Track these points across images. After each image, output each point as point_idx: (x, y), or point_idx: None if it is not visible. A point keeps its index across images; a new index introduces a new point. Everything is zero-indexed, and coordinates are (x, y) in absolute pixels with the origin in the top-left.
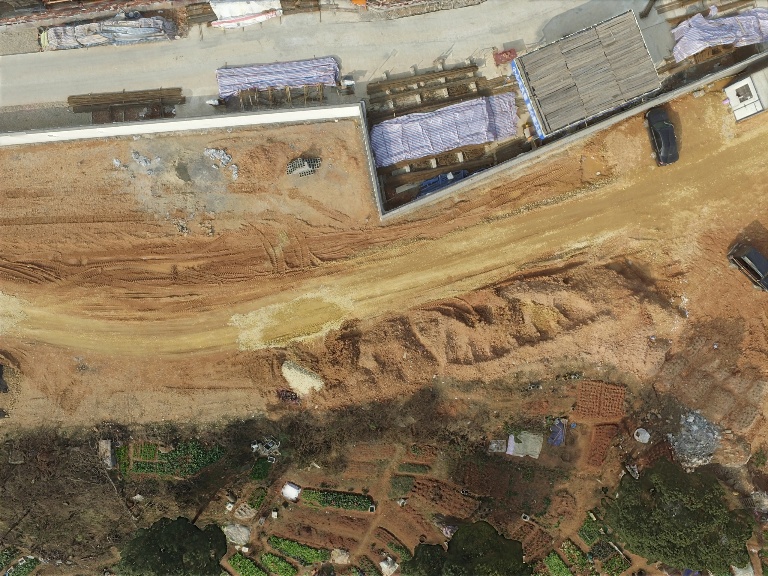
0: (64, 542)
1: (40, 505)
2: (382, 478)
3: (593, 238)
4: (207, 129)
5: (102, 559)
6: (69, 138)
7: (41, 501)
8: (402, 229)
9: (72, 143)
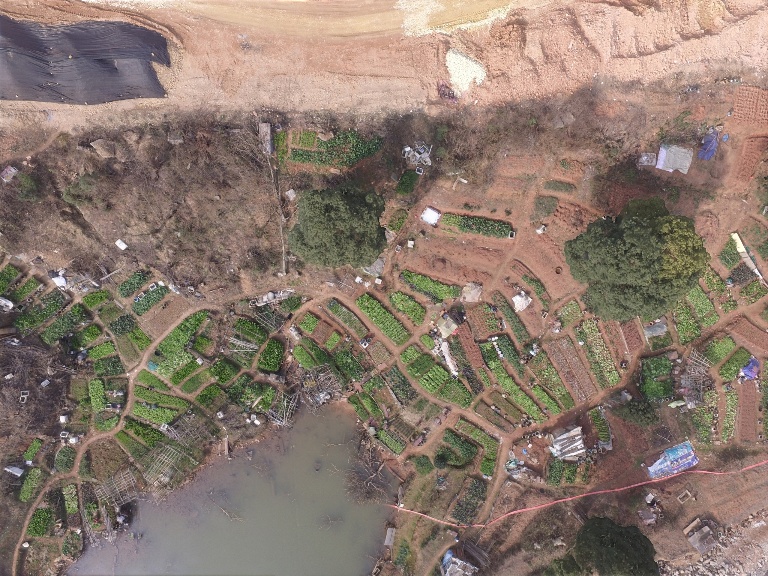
0: (200, 261)
1: (188, 203)
2: (526, 199)
3: None
4: None
5: (230, 294)
6: None
7: (193, 193)
8: None
9: None
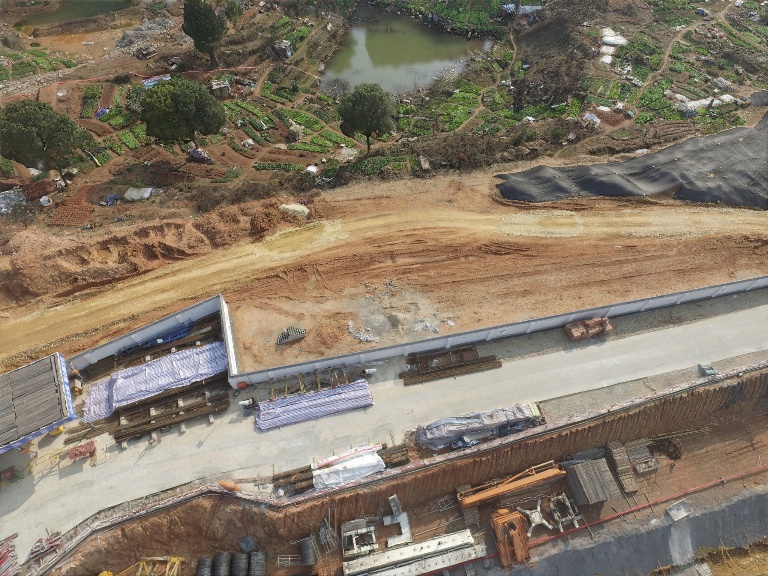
0: None
1: None
2: None
3: (42, 314)
4: None
5: None
6: (493, 336)
7: None
8: None
9: None
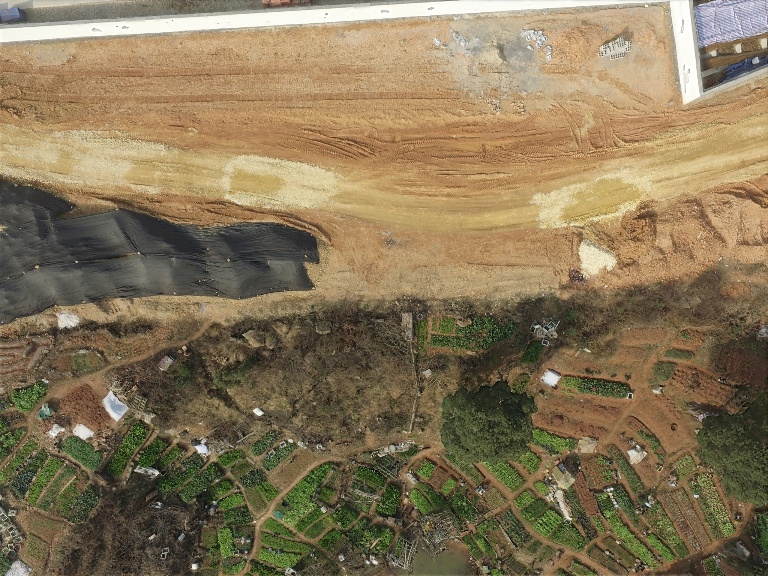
0: (331, 424)
1: (328, 380)
2: (645, 364)
3: None
4: (524, 11)
5: (354, 446)
6: (394, 16)
7: (335, 374)
8: (701, 113)
9: (395, 22)
